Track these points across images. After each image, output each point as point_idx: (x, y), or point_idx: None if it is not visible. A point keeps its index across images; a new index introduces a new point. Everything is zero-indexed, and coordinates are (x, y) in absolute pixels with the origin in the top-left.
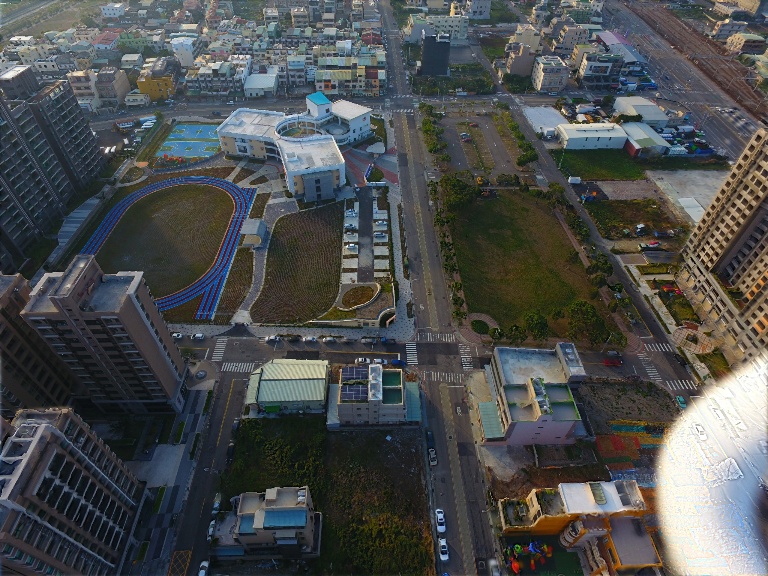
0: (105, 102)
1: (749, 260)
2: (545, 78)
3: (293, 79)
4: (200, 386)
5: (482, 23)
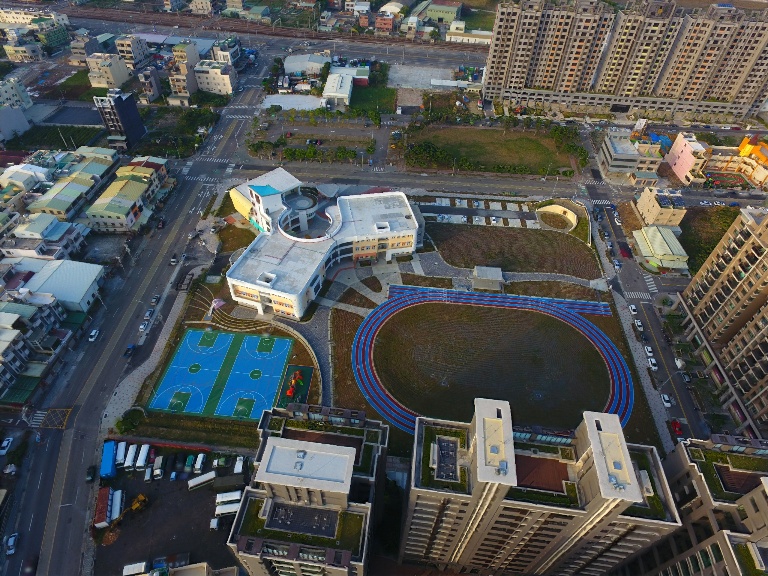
0: None
1: (534, 69)
2: (230, 79)
3: (69, 250)
4: None
5: None
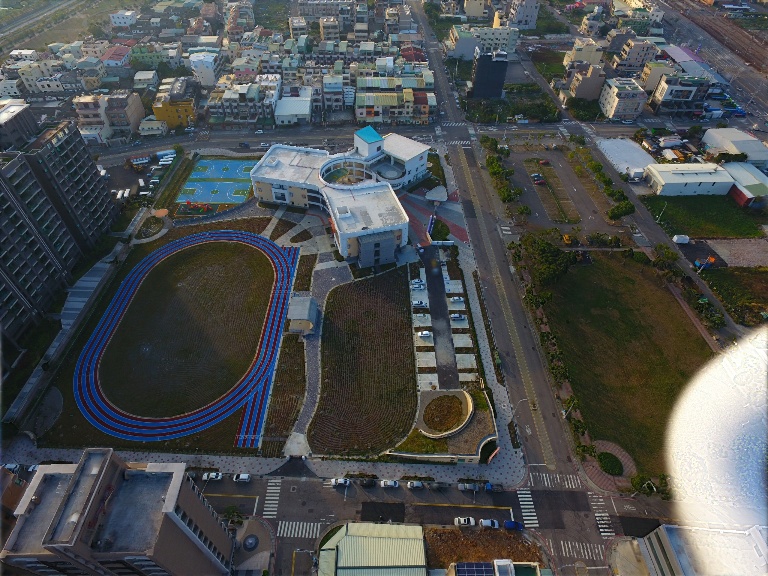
0: (116, 130)
1: None
2: (619, 104)
3: (329, 103)
4: (251, 563)
5: (529, 34)
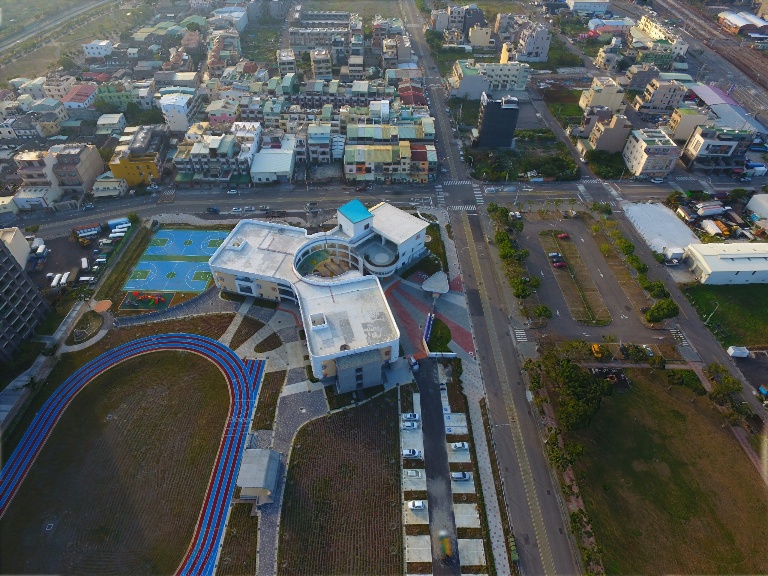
0: (67, 190)
1: None
2: (648, 161)
3: (315, 155)
4: None
5: (540, 68)
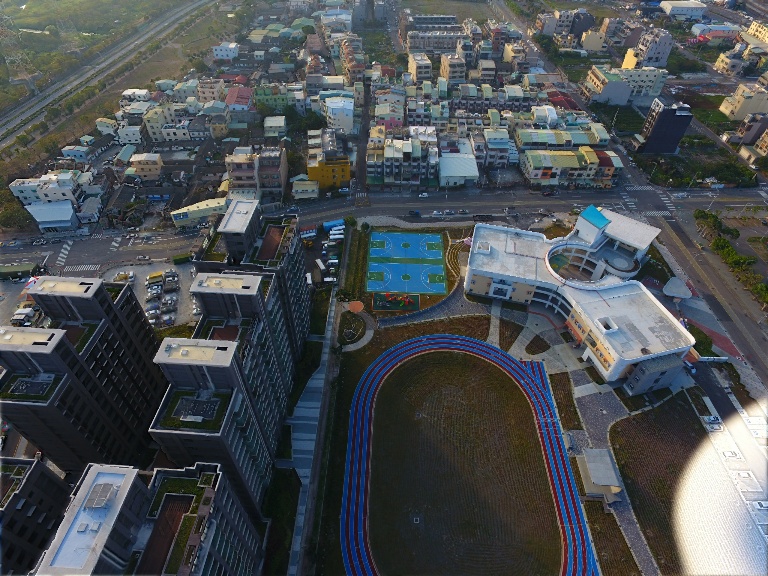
0: (264, 191)
1: None
2: None
3: (491, 160)
4: None
5: None
